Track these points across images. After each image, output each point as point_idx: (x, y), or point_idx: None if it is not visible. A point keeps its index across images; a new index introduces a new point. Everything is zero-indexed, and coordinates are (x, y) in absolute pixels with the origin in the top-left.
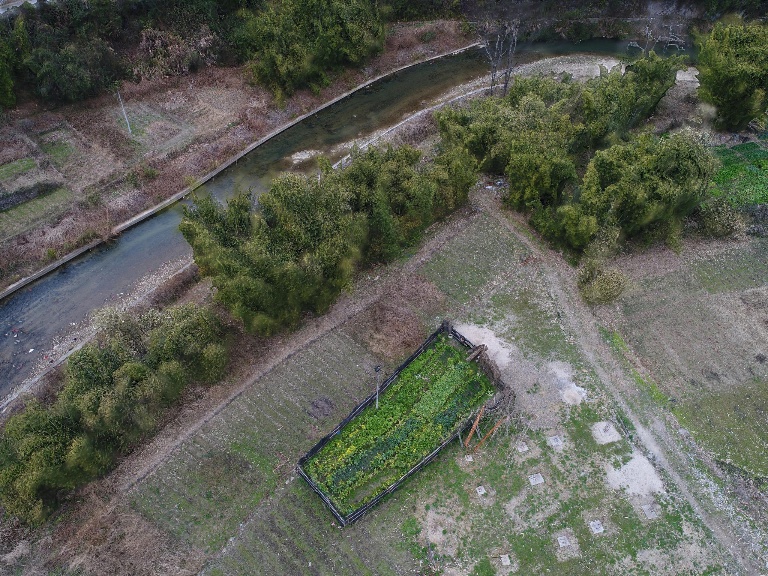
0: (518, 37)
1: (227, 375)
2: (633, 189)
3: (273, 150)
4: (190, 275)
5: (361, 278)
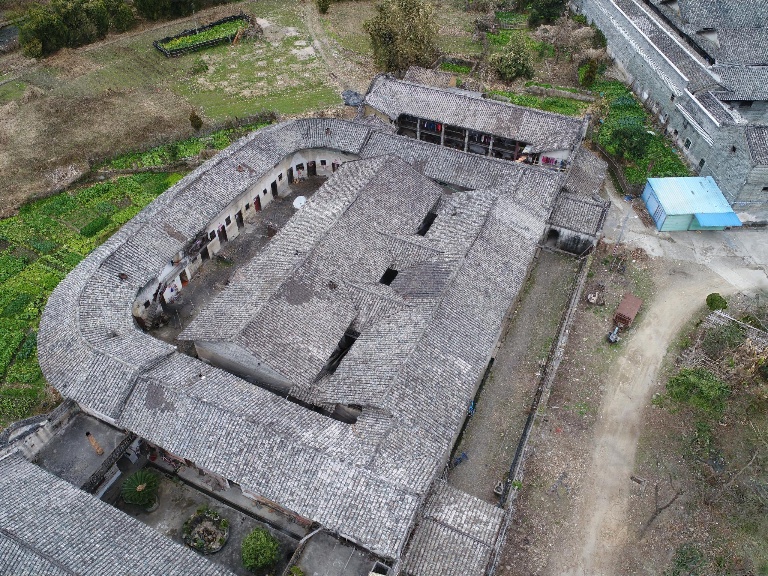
0: None
1: (132, 29)
2: None
3: None
4: None
5: (211, 8)
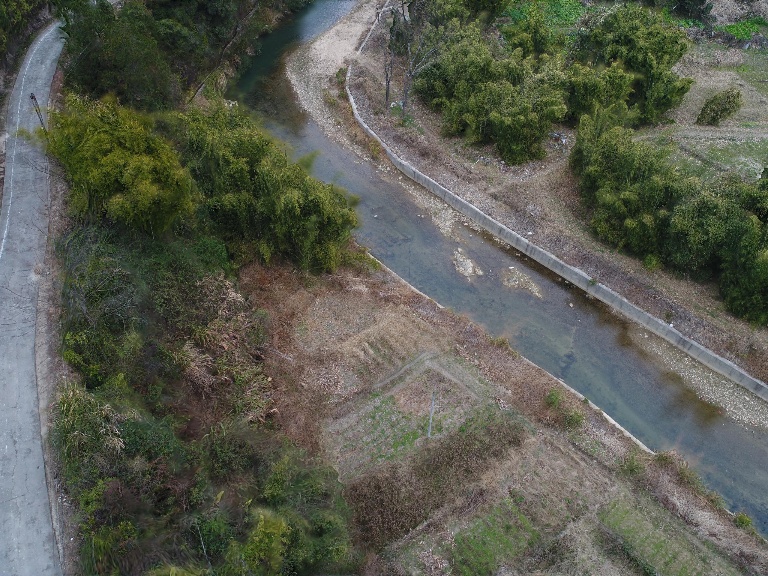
0: (236, 77)
1: None
2: (683, 46)
3: (443, 294)
4: (752, 352)
5: None
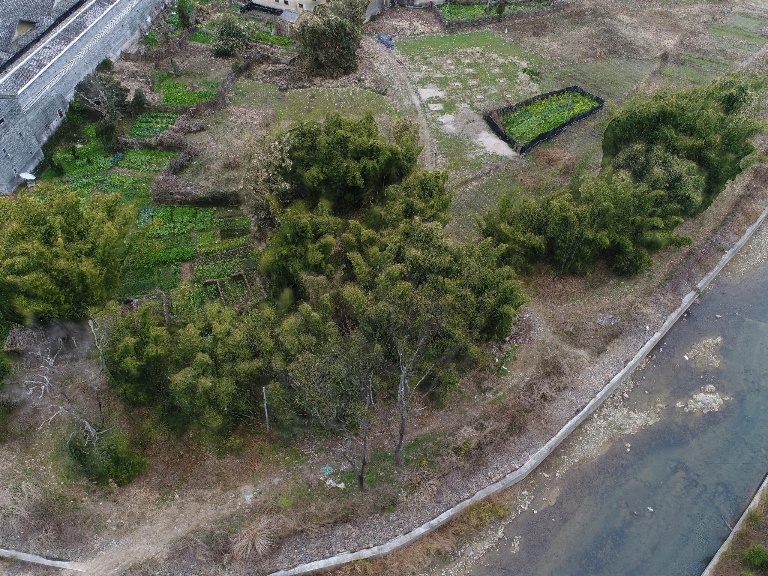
0: None
1: None
2: None
3: (761, 427)
4: None
5: None
